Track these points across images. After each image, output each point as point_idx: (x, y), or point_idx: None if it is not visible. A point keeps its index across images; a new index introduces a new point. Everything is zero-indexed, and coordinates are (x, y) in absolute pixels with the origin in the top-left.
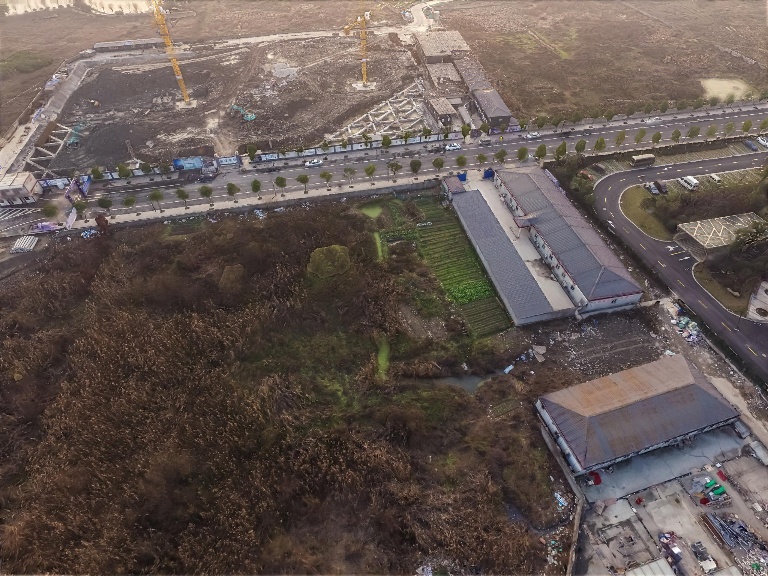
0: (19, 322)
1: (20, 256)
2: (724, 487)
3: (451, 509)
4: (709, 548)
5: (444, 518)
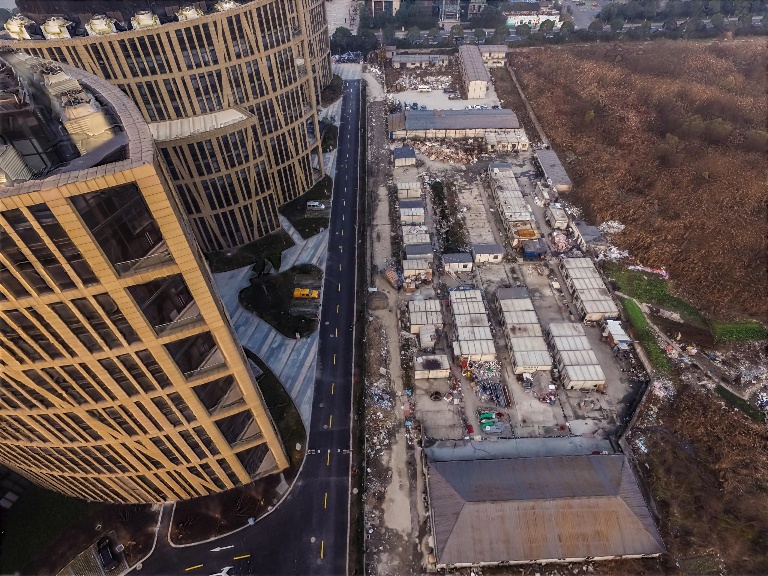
0: None
1: None
2: (475, 421)
3: (759, 464)
4: (517, 387)
5: (765, 458)
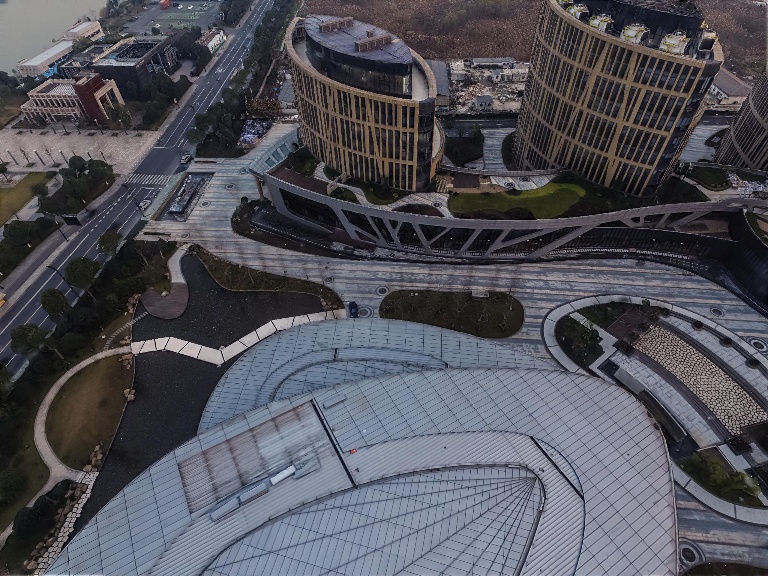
0: (718, 5)
1: (753, 5)
2: None
3: None
4: None
5: None
